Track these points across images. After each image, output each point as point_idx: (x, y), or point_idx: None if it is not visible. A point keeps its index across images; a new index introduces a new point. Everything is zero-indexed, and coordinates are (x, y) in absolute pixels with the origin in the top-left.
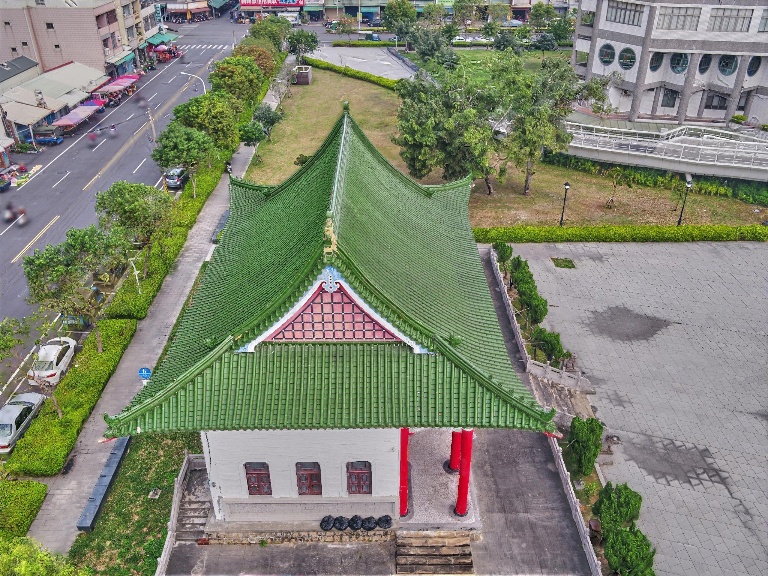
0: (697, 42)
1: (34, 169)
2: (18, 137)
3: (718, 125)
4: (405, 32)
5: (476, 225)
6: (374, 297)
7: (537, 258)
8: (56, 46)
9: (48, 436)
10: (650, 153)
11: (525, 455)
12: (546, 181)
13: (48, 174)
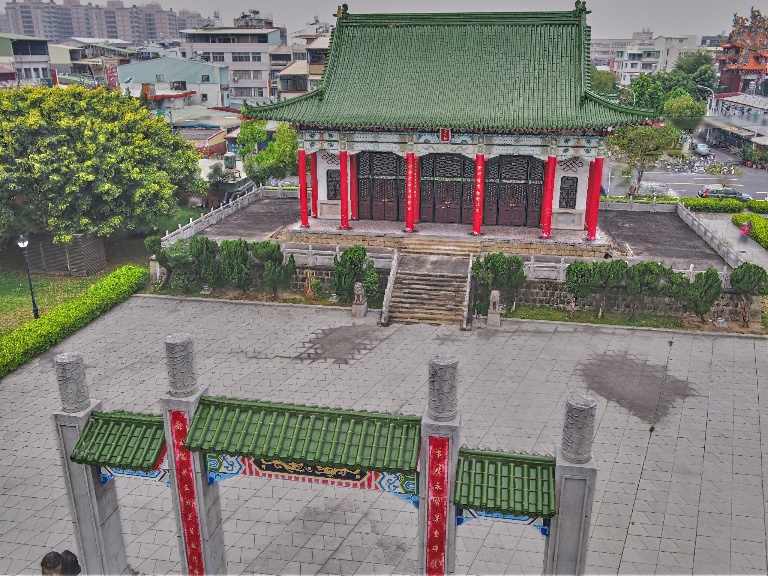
0: None
1: None
2: None
3: None
4: None
5: None
6: None
7: None
8: None
9: None
10: None
11: None
12: None
13: None
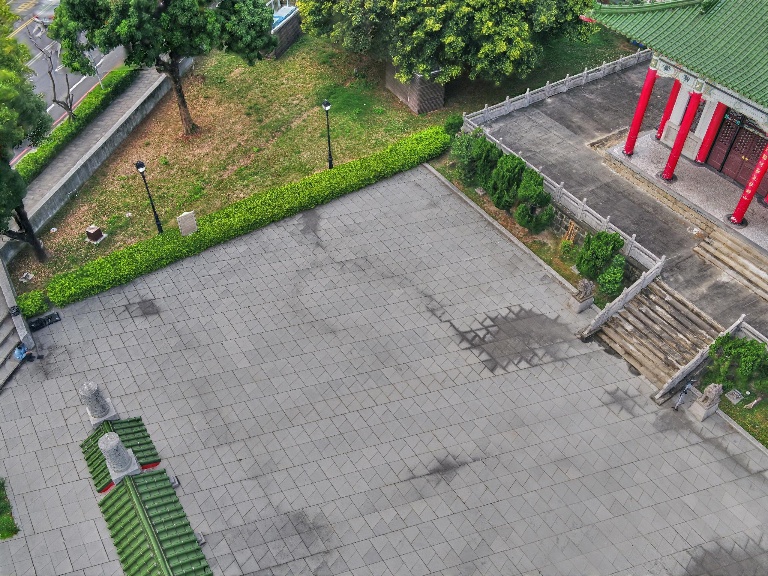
0: None
1: None
2: None
3: None
4: None
5: None
6: None
7: None
8: None
9: None
10: None
11: (635, 233)
12: None
13: None
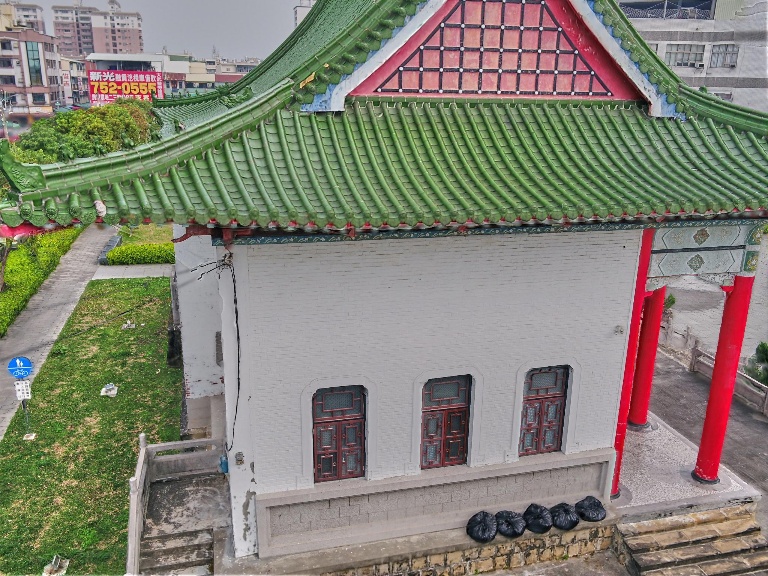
0: None
1: None
2: None
3: None
4: None
5: None
6: None
7: None
8: None
9: None
10: None
11: None
12: None
13: None
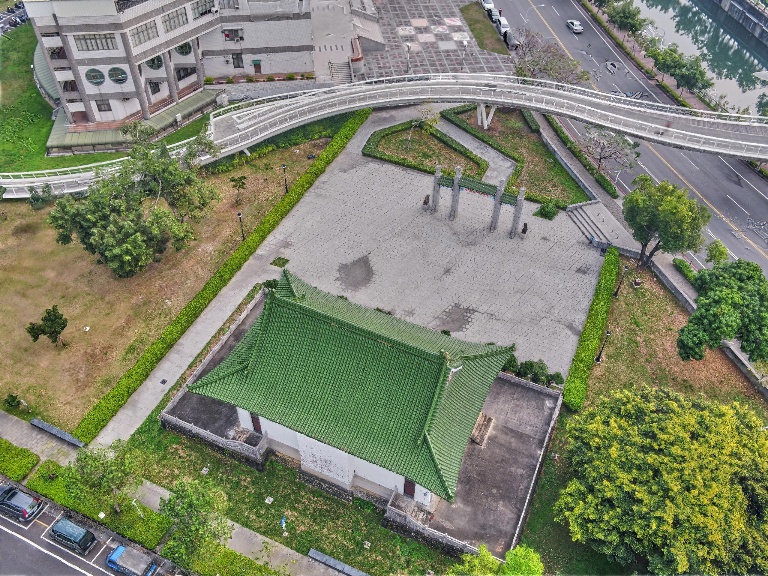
0: (163, 44)
1: None
2: None
3: (199, 91)
4: None
5: (197, 277)
6: None
7: (265, 270)
8: None
9: None
10: None
11: None
12: None
13: None
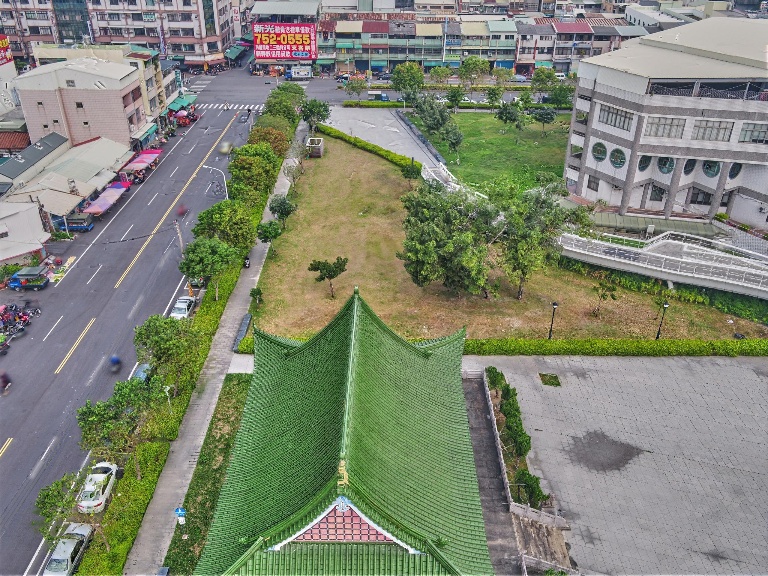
0: (682, 149)
1: (69, 261)
2: (53, 226)
3: (702, 221)
4: (412, 98)
5: (473, 333)
6: (377, 513)
7: (526, 374)
8: (85, 123)
9: (99, 571)
10: (635, 261)
11: None
12: (539, 282)
13: (82, 268)
